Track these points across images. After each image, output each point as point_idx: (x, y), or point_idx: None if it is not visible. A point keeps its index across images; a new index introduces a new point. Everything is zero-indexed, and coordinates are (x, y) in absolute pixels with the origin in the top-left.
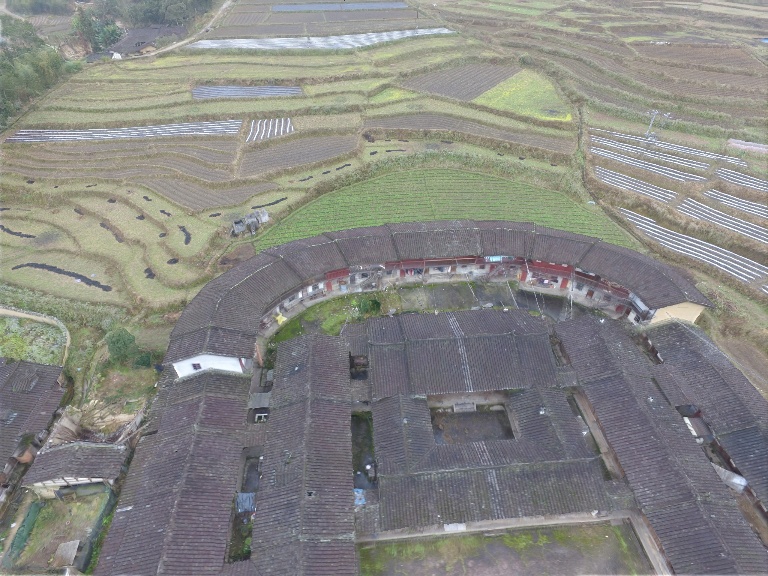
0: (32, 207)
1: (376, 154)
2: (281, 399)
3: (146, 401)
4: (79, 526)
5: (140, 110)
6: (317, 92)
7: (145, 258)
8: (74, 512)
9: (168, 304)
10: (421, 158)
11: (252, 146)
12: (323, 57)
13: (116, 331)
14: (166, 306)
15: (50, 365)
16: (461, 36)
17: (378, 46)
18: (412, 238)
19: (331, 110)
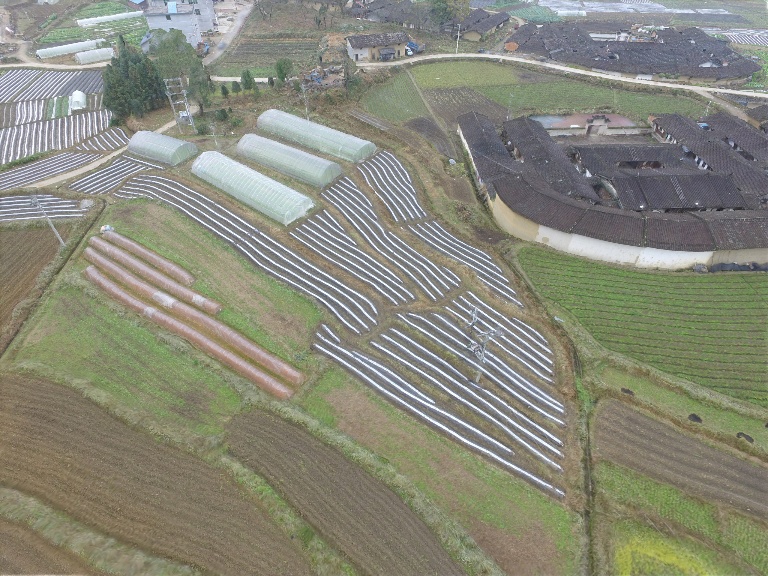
0: None
1: None
2: (760, 168)
3: None
4: None
5: None
6: None
7: None
8: None
9: None
10: None
11: None
12: None
13: None
14: None
15: None
16: None
17: None
18: (767, 215)
19: None
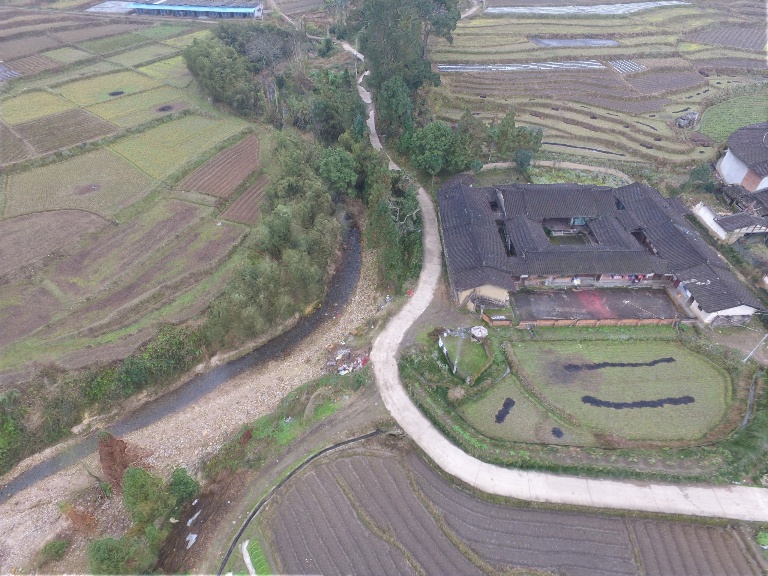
0: (497, 113)
1: (722, 84)
2: None
3: (724, 208)
4: (763, 255)
5: (511, 53)
6: (634, 43)
7: (635, 138)
8: (752, 250)
9: (686, 161)
10: (760, 86)
11: (628, 76)
12: (604, 20)
13: (705, 163)
14: (684, 162)
15: (651, 187)
16: (697, 7)
17: (641, 13)
18: None
19: (658, 55)
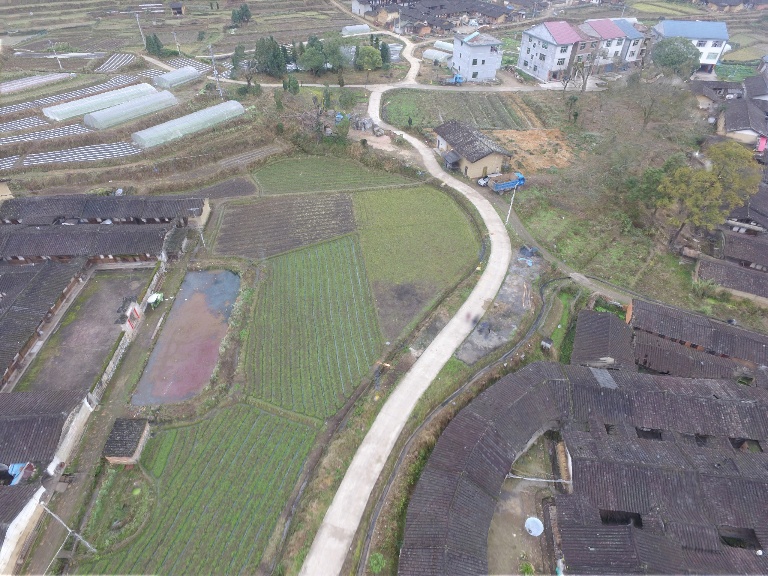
0: None
1: None
2: None
3: None
4: None
5: None
6: None
7: None
8: None
9: None
10: None
11: None
12: None
13: None
14: None
15: None
16: None
17: None
18: None
19: None
